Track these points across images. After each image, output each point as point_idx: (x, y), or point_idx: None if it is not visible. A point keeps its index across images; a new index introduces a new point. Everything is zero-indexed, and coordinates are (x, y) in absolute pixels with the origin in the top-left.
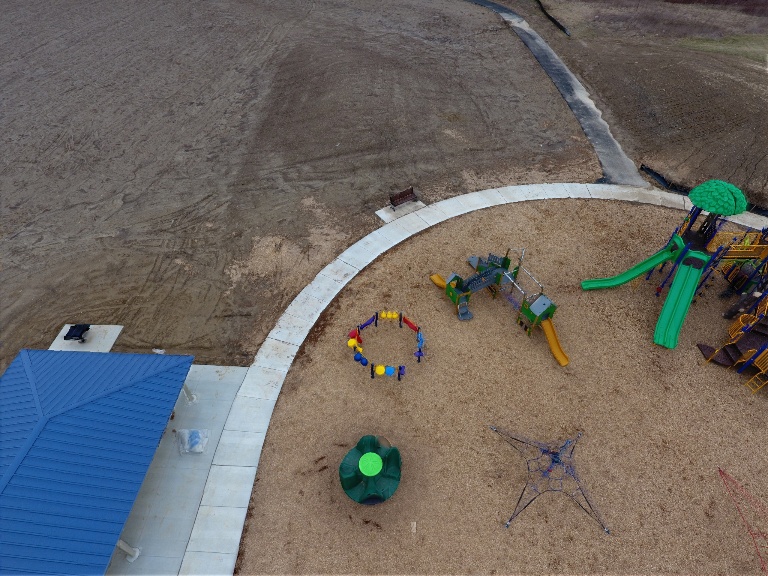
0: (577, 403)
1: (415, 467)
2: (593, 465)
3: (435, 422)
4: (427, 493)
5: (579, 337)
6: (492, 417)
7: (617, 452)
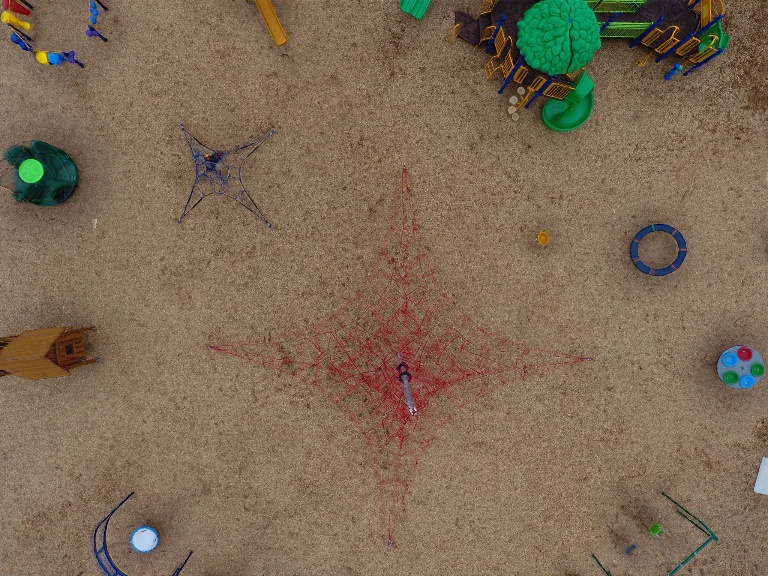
0: (283, 94)
1: (97, 168)
2: (276, 165)
3: (121, 119)
4: (108, 193)
5: (314, 0)
6: (183, 113)
7: (306, 151)
